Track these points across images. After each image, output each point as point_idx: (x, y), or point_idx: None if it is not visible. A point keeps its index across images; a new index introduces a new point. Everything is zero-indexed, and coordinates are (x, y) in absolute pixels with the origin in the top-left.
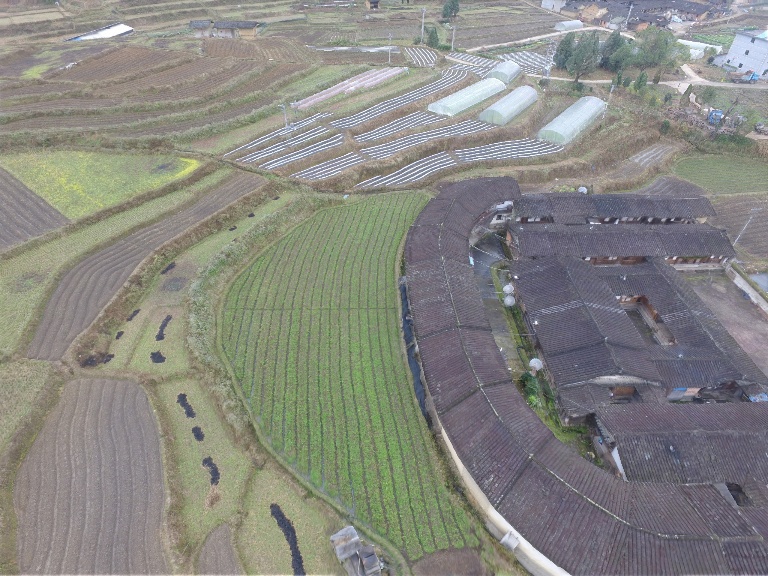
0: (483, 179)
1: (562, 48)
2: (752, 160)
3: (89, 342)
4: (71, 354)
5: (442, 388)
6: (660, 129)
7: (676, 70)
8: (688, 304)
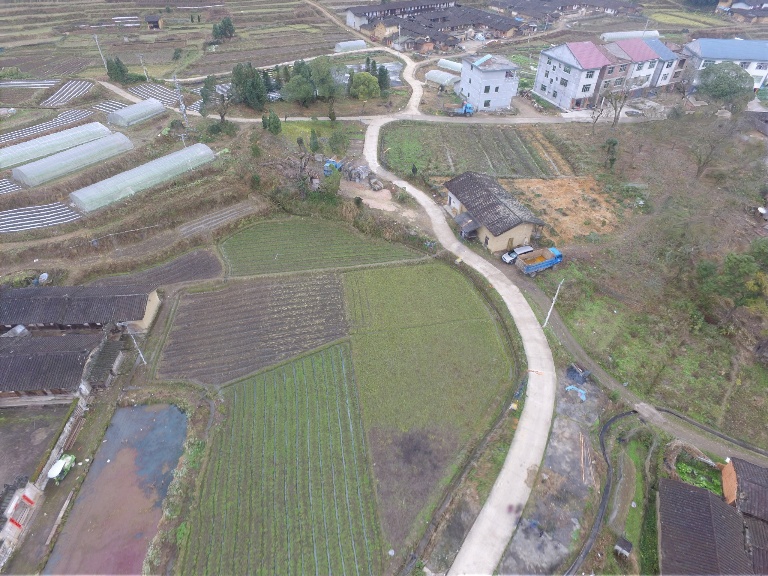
0: None
1: (232, 81)
2: (335, 224)
3: None
4: None
5: None
6: (253, 185)
7: (389, 102)
8: None
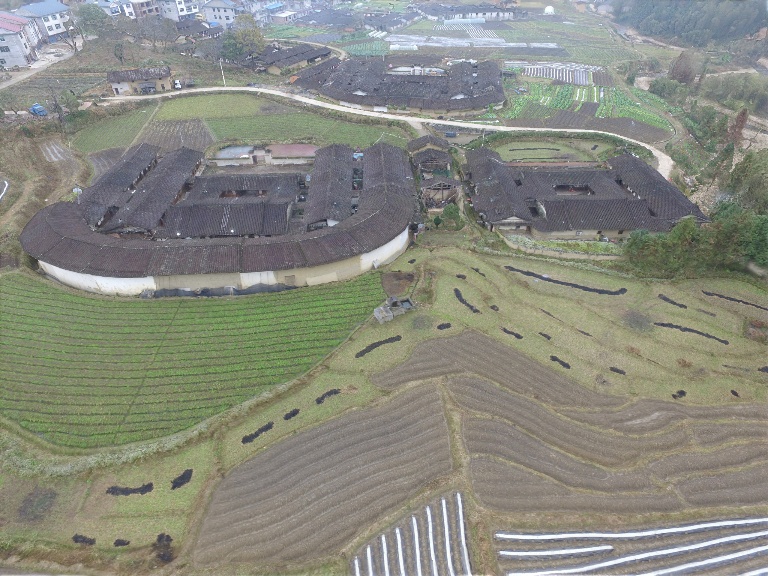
0: (34, 222)
1: None
2: (102, 122)
3: (130, 567)
4: (152, 574)
5: (290, 261)
6: (25, 135)
7: None
8: None
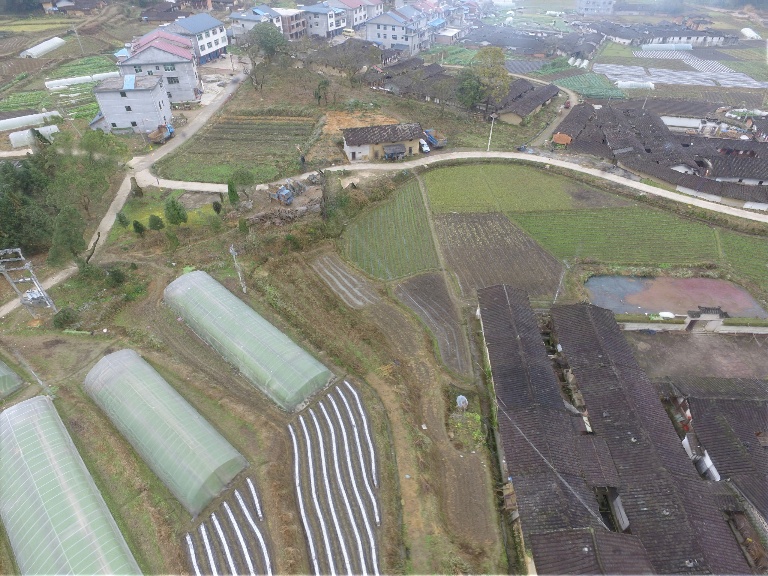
0: None
1: None
2: (365, 213)
3: None
4: None
5: None
6: (290, 248)
7: None
8: (765, 397)
